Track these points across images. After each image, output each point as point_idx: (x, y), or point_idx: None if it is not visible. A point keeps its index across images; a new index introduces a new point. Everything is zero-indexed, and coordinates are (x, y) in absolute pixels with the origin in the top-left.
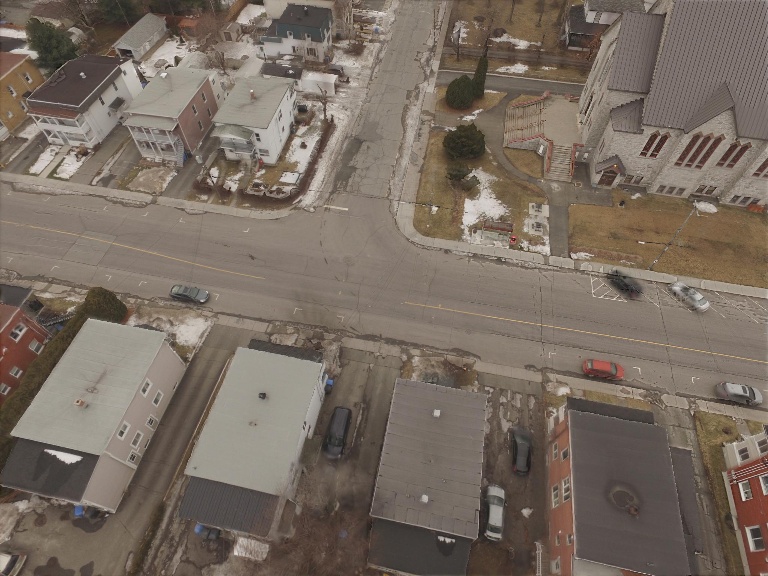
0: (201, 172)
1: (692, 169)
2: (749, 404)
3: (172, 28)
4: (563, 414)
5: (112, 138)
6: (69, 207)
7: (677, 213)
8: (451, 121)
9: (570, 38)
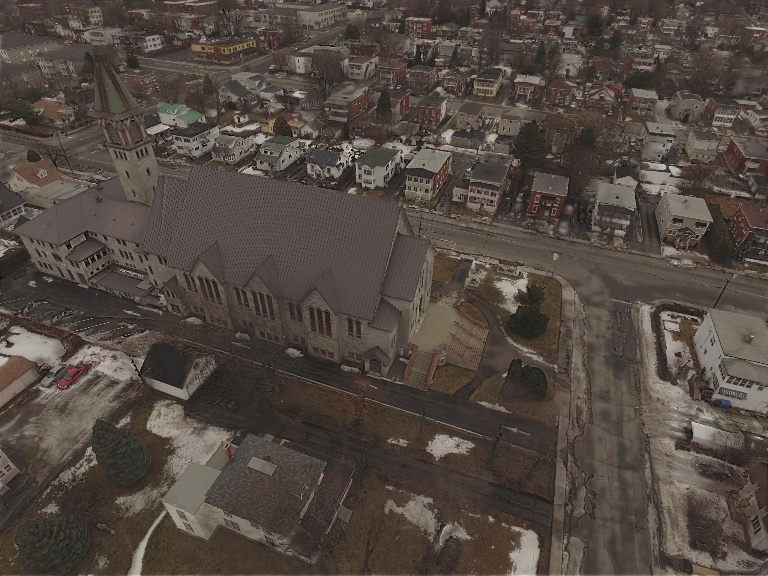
0: None
1: None
2: None
3: None
4: None
5: None
6: None
7: None
8: None
9: None
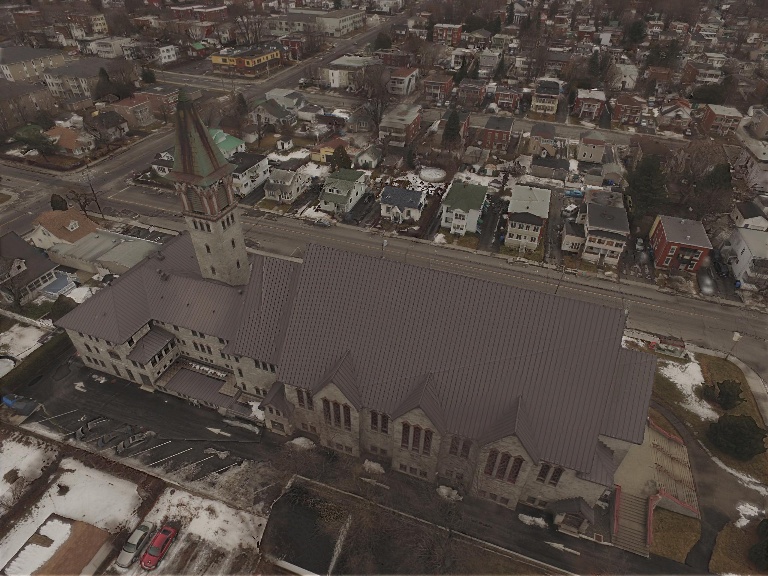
0: None
1: None
2: None
3: None
4: None
5: None
6: None
7: None
8: None
9: None
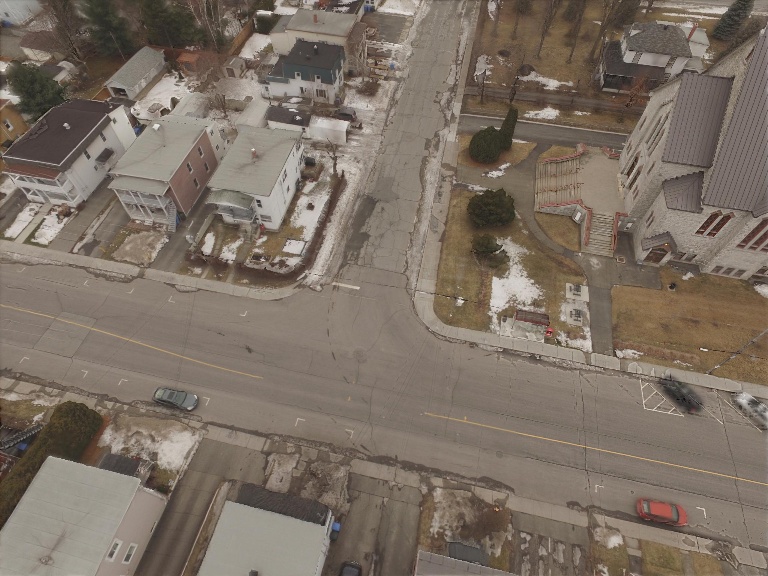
0: (195, 240)
1: (757, 252)
2: None
3: (171, 61)
4: None
5: (99, 194)
6: (46, 281)
7: (736, 299)
8: (475, 177)
9: (605, 79)
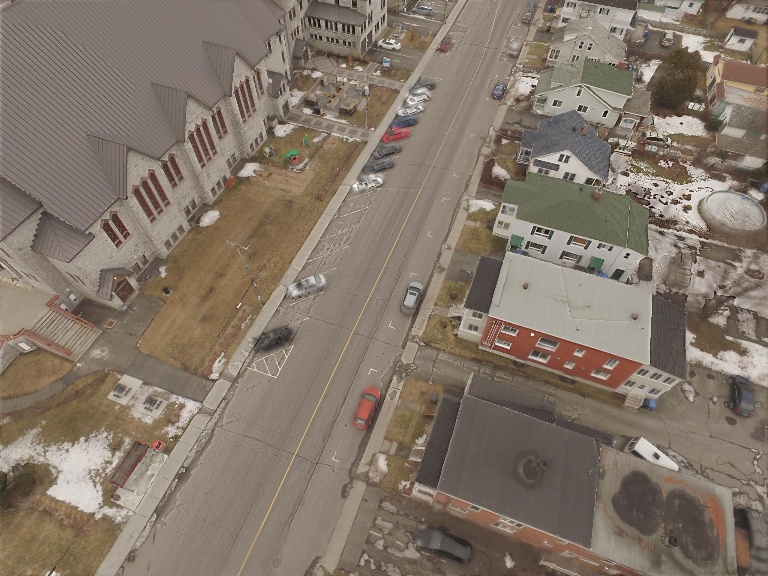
0: None
1: (166, 211)
2: (421, 295)
3: None
4: (427, 488)
5: None
6: None
7: (205, 246)
8: None
9: None
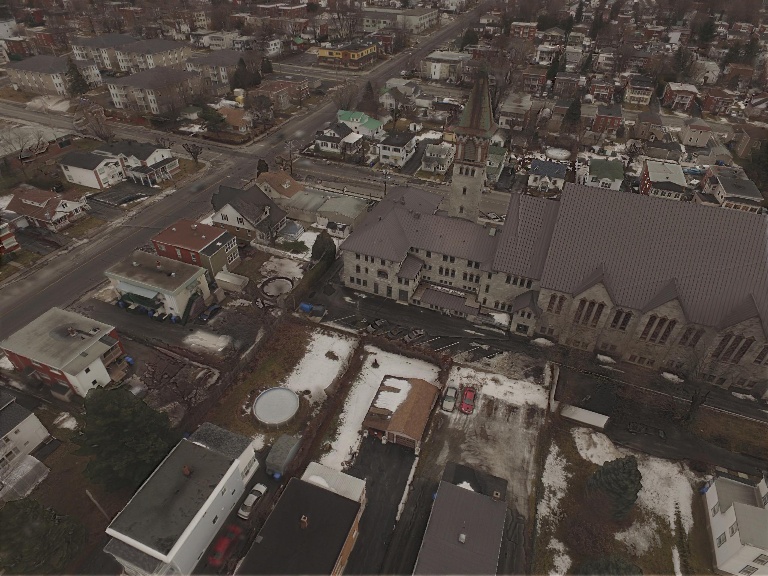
0: None
1: None
2: None
3: None
4: None
5: None
6: None
7: None
8: None
9: None
